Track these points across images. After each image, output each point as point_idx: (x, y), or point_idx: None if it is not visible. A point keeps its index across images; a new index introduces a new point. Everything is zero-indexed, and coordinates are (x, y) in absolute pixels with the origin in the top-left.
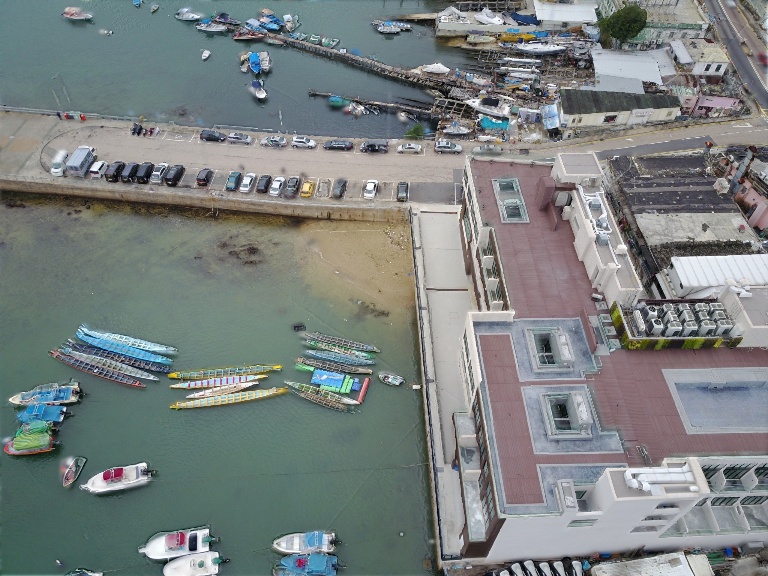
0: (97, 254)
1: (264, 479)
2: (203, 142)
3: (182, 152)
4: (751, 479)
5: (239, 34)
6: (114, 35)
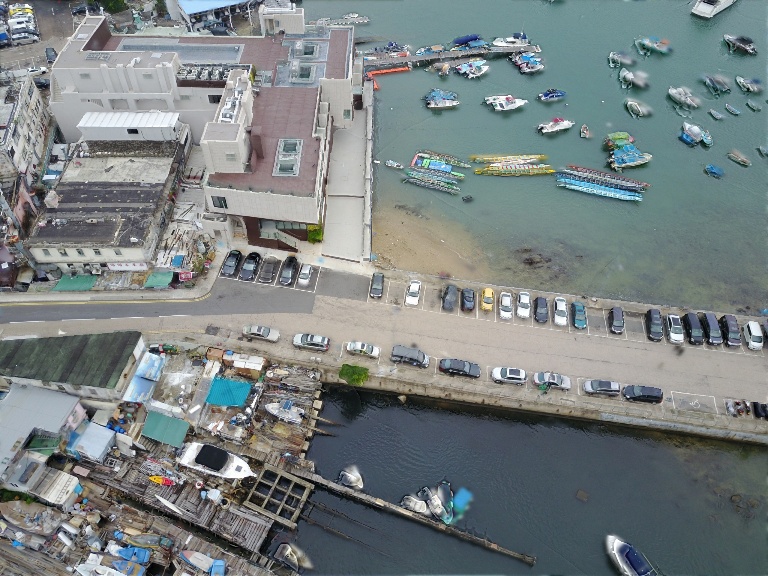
0: (680, 264)
1: None
2: None
3: (670, 370)
4: None
5: None
6: None
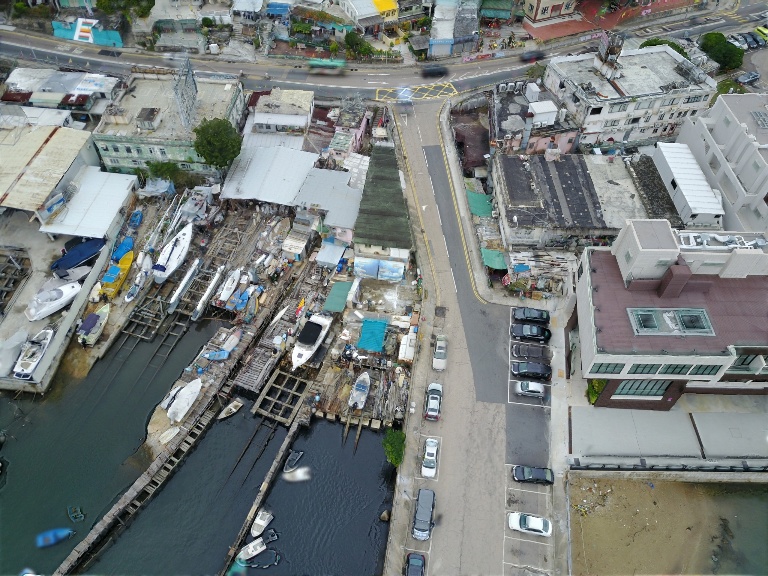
0: None
1: None
2: None
3: None
4: None
5: None
6: None
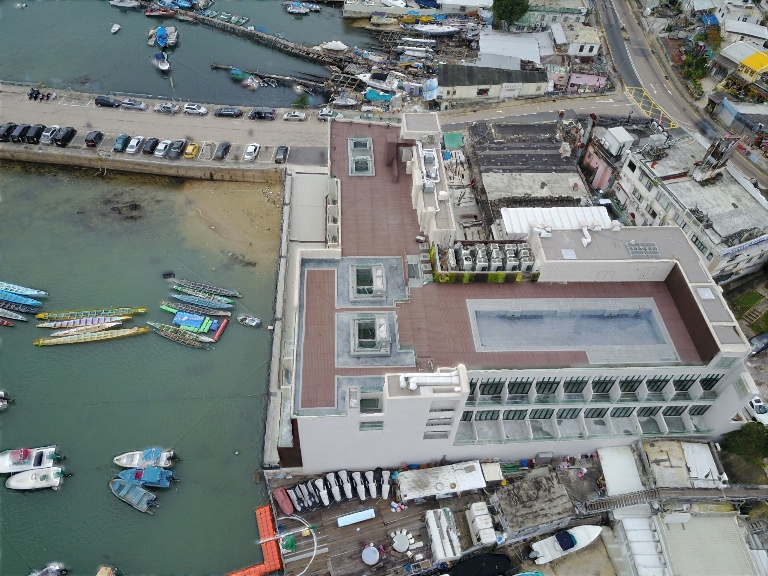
0: None
1: (115, 406)
2: (98, 107)
3: (76, 116)
4: (533, 392)
5: (150, 10)
6: (27, 8)
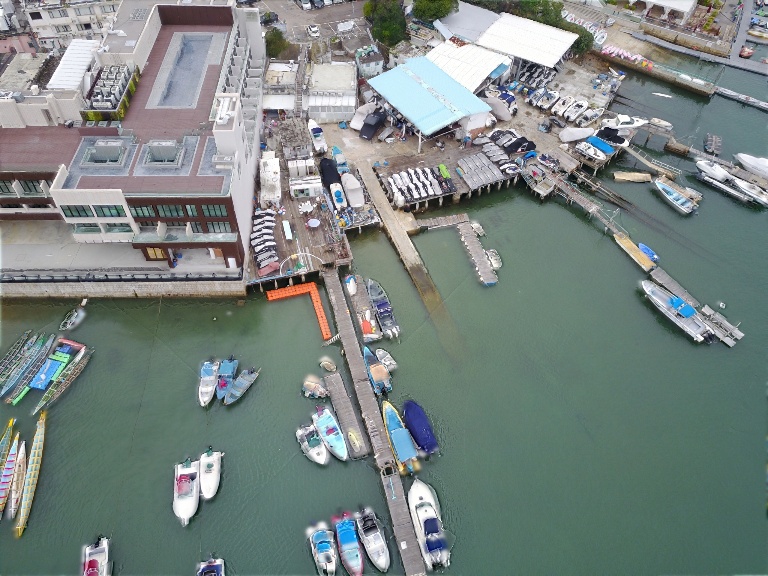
0: None
1: (140, 424)
2: None
3: None
4: None
5: None
6: None
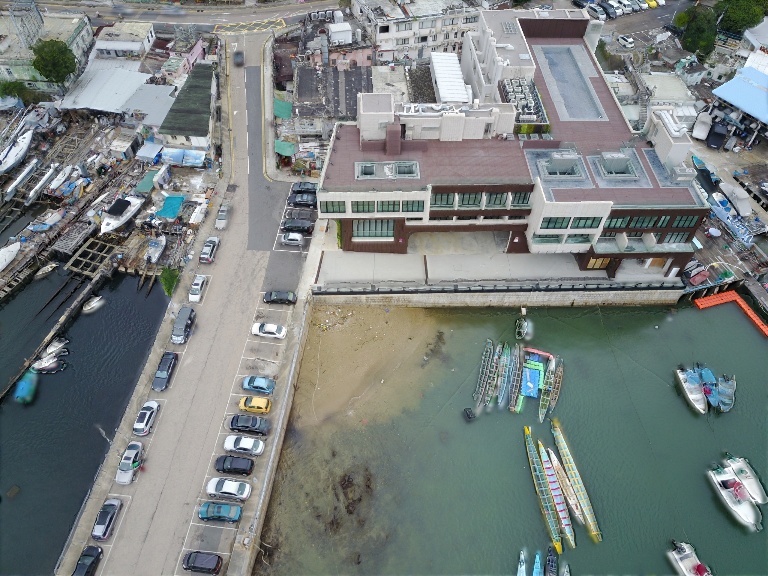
0: None
1: (648, 431)
2: None
3: None
4: None
5: None
6: None
